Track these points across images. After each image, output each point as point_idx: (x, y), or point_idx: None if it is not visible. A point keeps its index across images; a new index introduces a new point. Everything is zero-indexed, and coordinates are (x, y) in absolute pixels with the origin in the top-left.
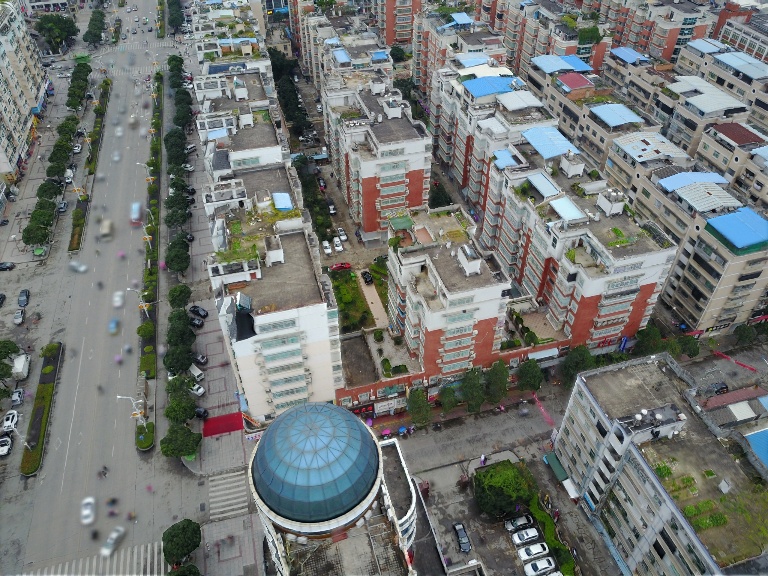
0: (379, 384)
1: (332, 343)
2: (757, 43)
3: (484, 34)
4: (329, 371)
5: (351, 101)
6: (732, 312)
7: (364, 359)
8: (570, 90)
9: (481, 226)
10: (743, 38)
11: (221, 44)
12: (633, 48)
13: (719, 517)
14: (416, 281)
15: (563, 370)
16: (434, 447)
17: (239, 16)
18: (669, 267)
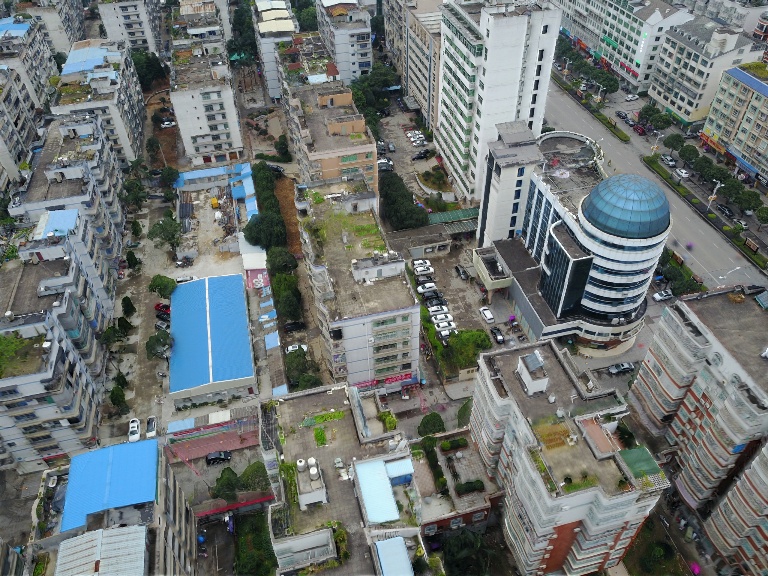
0: None
1: None
2: None
3: None
4: None
5: None
6: None
7: None
8: None
9: None
10: None
11: None
12: None
13: (358, 227)
14: None
15: None
16: None
17: None
18: None
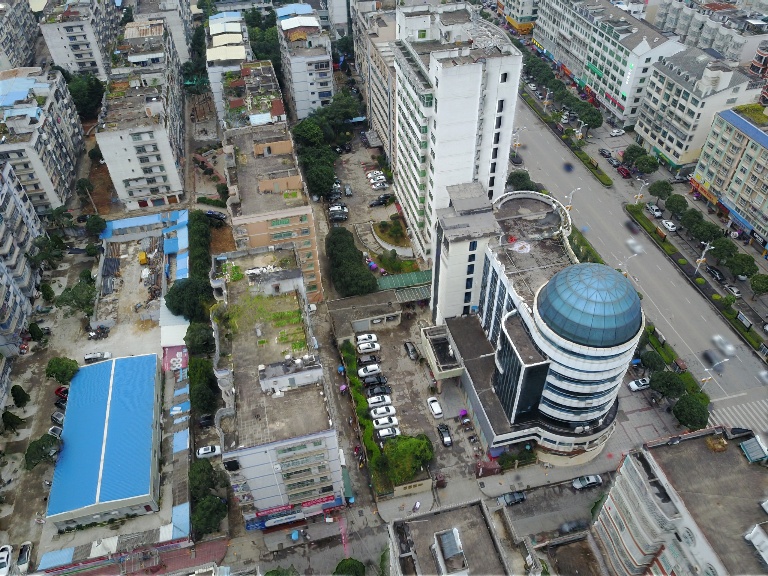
0: None
1: None
2: None
3: None
4: None
5: None
6: None
7: None
8: None
9: None
10: None
11: None
12: None
13: (276, 315)
14: None
15: None
16: None
17: None
18: None
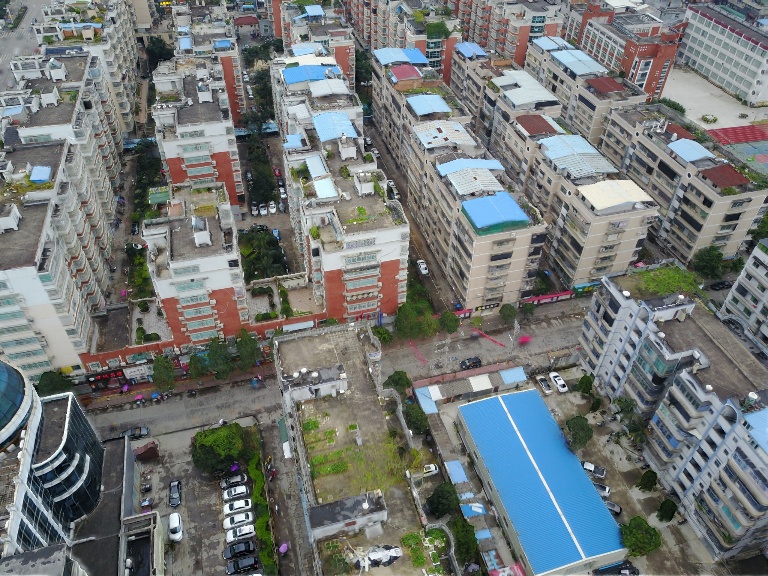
0: (126, 350)
1: (56, 307)
2: (609, 43)
3: (334, 26)
4: (64, 335)
5: (179, 86)
6: (496, 292)
7: (123, 328)
8: (397, 81)
9: None
10: (600, 38)
11: (63, 28)
12: (495, 45)
13: (341, 465)
14: (160, 252)
15: None
16: (182, 412)
17: (100, 3)
18: (407, 244)
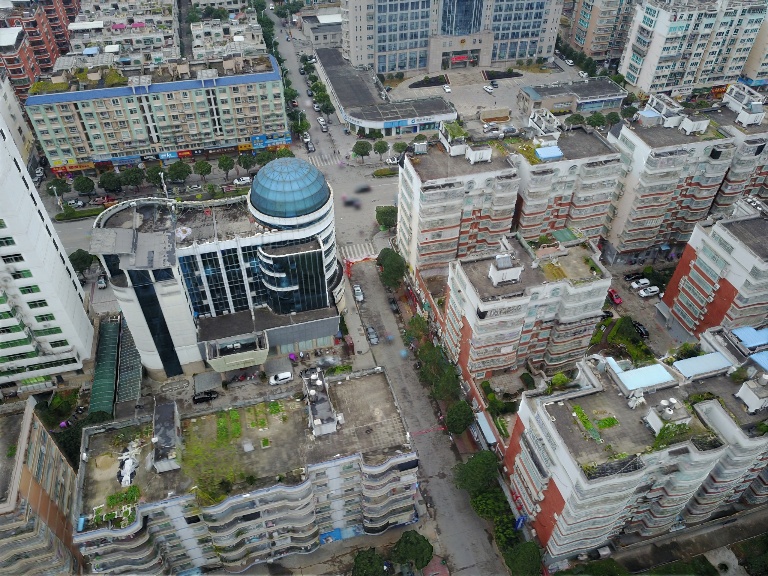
0: None
1: None
2: None
3: None
4: None
5: None
6: None
7: None
8: None
9: None
10: None
11: None
12: None
13: (223, 433)
14: None
15: None
16: (397, 363)
17: None
18: (577, 499)
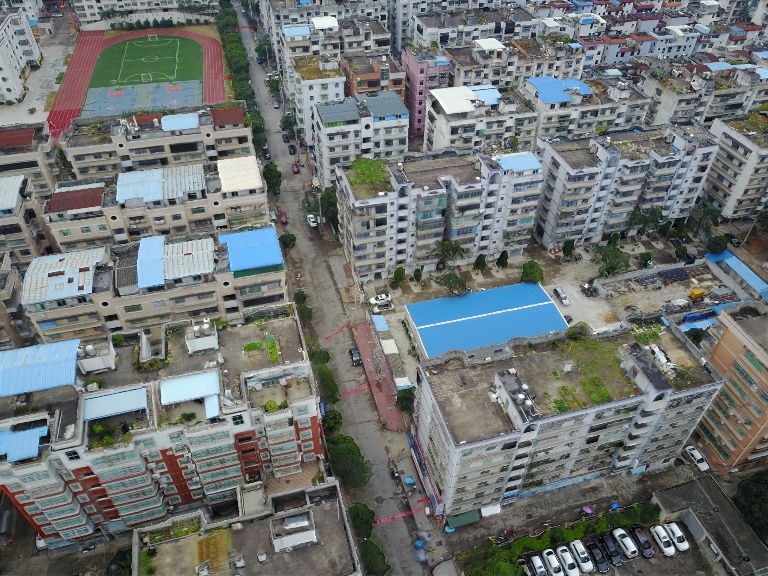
0: None
1: None
2: None
3: None
4: None
5: None
6: None
7: None
8: None
9: (4, 544)
10: None
11: None
12: None
13: (597, 380)
14: None
15: (344, 481)
16: None
17: None
18: None
